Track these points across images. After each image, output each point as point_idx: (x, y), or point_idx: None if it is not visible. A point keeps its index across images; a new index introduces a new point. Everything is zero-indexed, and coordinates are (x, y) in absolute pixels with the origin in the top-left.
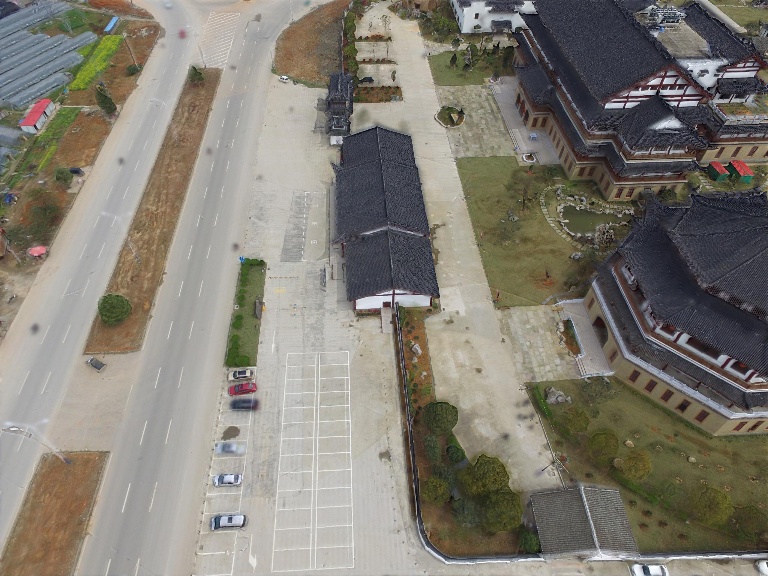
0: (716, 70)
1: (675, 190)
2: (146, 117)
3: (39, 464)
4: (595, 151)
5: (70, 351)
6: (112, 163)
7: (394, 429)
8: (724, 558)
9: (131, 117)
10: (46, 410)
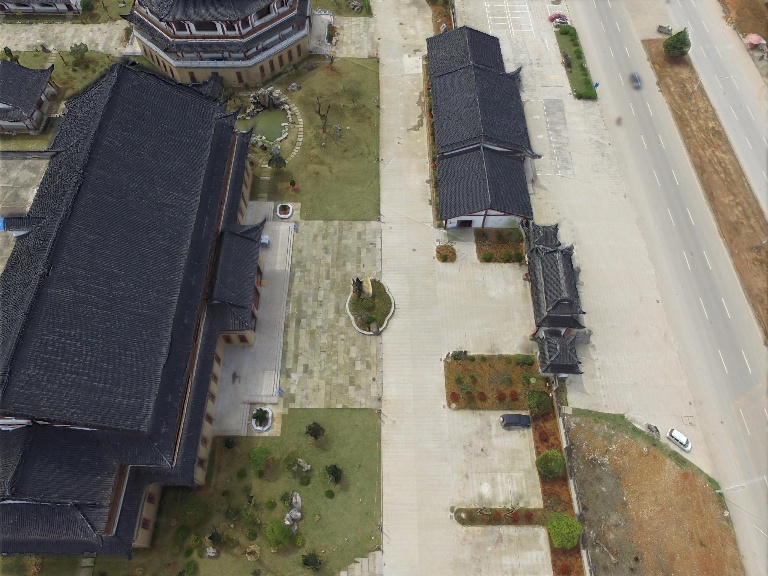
0: None
1: None
2: None
3: None
4: None
5: (690, 39)
6: None
7: (459, 1)
8: None
9: None
10: None
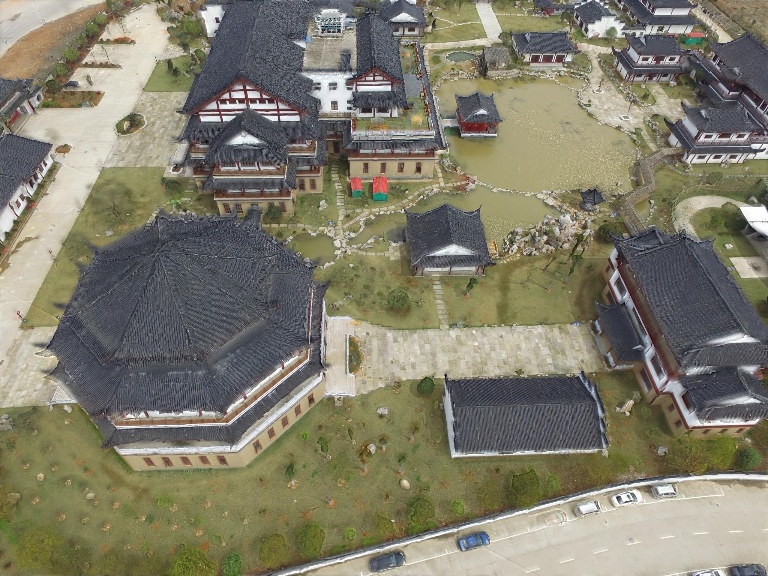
0: (345, 83)
1: (286, 207)
2: None
3: None
4: None
5: None
6: None
7: None
8: None
9: None
10: None
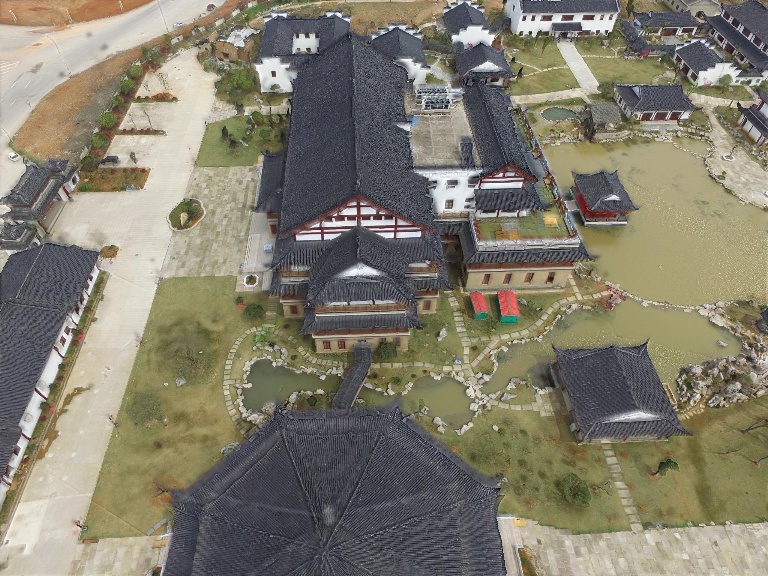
0: (467, 181)
1: (400, 342)
2: None
3: None
4: (293, 292)
5: None
6: None
7: None
8: None
9: None
10: None
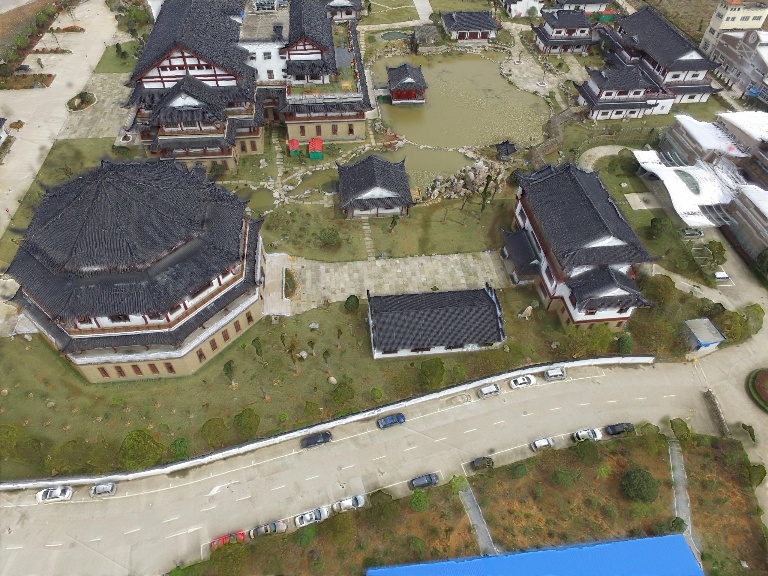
0: (278, 53)
1: (228, 165)
2: None
3: None
4: (146, 129)
5: None
6: None
7: None
8: (16, 489)
9: None
10: None
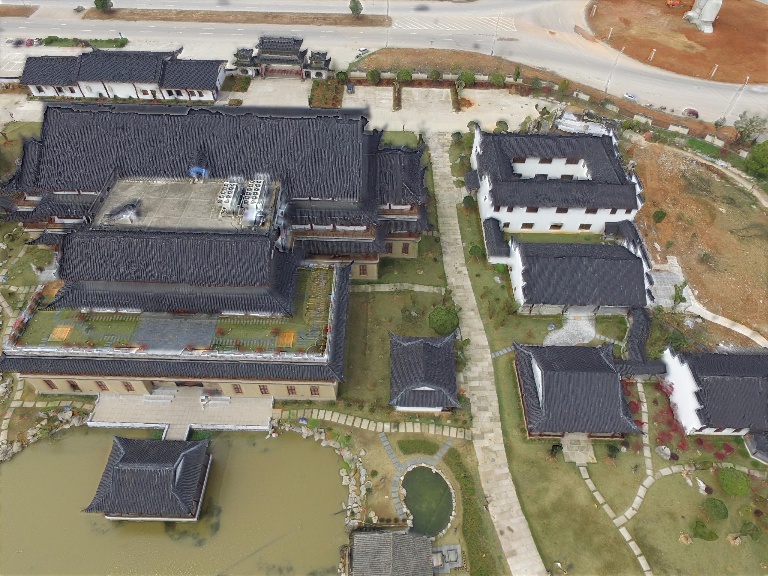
0: None
1: None
2: (315, 6)
3: (35, 5)
4: None
5: None
6: (257, 0)
7: None
8: None
9: (316, 1)
10: (64, 4)
